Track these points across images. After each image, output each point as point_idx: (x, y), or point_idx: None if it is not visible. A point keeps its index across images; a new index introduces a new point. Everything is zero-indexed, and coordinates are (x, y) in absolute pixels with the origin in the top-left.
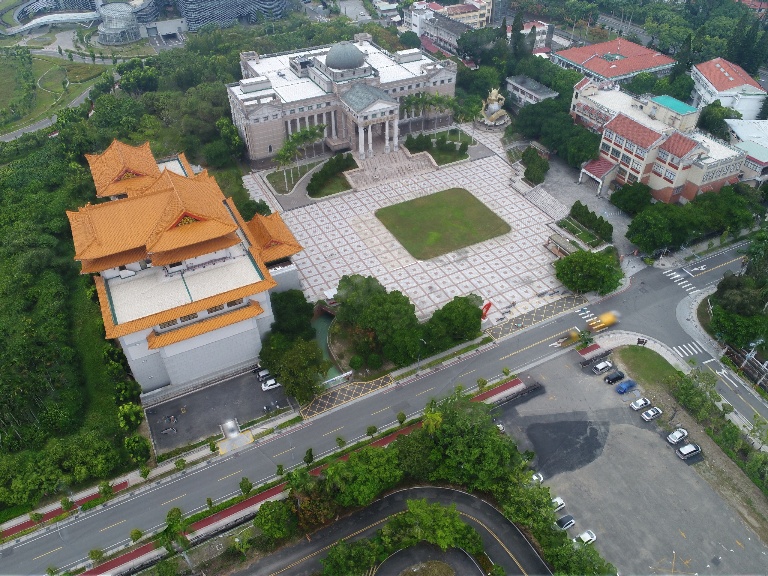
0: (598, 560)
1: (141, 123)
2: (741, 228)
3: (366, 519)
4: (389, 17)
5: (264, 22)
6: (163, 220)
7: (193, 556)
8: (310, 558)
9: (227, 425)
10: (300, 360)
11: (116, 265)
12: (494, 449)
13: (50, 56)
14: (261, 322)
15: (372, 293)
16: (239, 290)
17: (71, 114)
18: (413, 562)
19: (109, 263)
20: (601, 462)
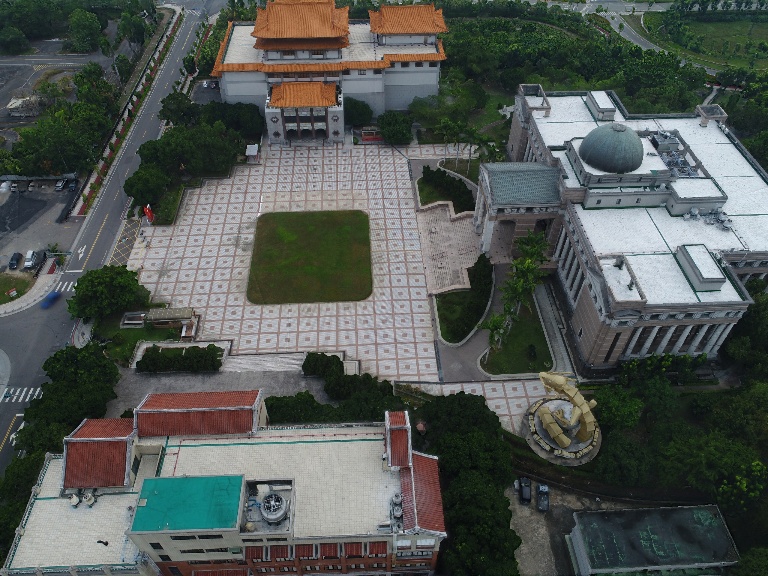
0: None
1: None
2: None
3: None
4: None
5: None
6: None
7: None
8: None
9: None
10: (170, 95)
11: None
12: None
13: None
14: None
15: (200, 135)
16: None
17: (639, 49)
18: None
19: None
20: None
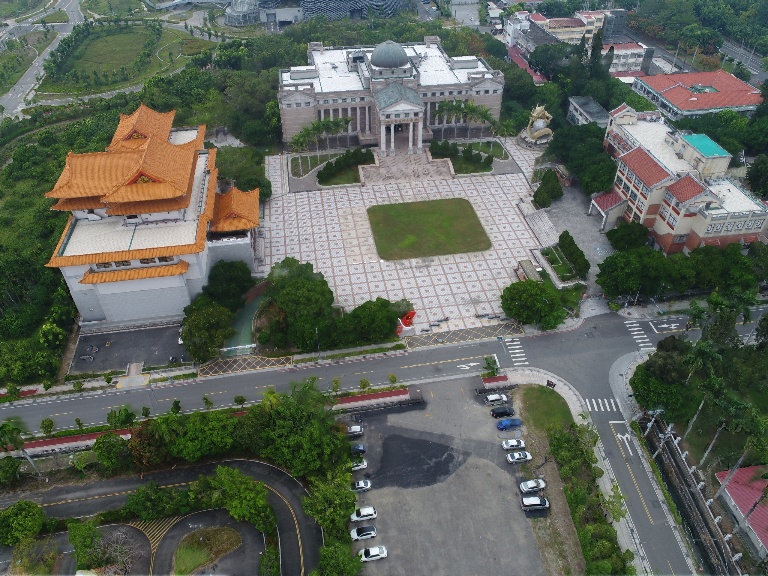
0: (350, 570)
1: (206, 96)
2: (736, 292)
3: (196, 475)
4: (497, 24)
5: (372, 18)
6: (128, 176)
7: (49, 463)
8: (133, 493)
9: (135, 365)
10: (199, 321)
11: (82, 208)
12: (314, 441)
13: (180, 30)
14: (193, 283)
15: (299, 277)
16: (169, 248)
17: (156, 81)
18: (212, 523)
19: (77, 205)
20: (438, 488)
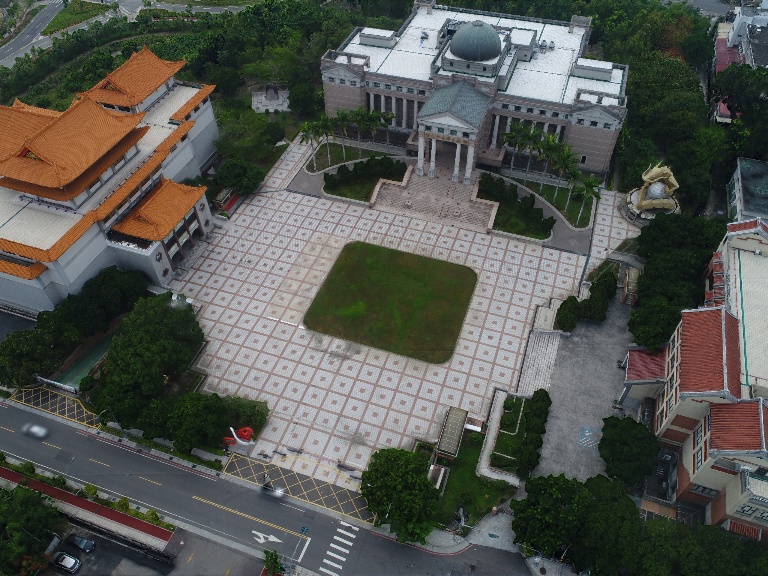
0: None
1: (288, 38)
2: None
3: None
4: None
5: None
6: None
7: None
8: None
9: None
10: (8, 345)
11: None
12: None
13: None
14: (59, 287)
15: None
16: (22, 246)
17: (257, 6)
18: None
19: None
20: None
